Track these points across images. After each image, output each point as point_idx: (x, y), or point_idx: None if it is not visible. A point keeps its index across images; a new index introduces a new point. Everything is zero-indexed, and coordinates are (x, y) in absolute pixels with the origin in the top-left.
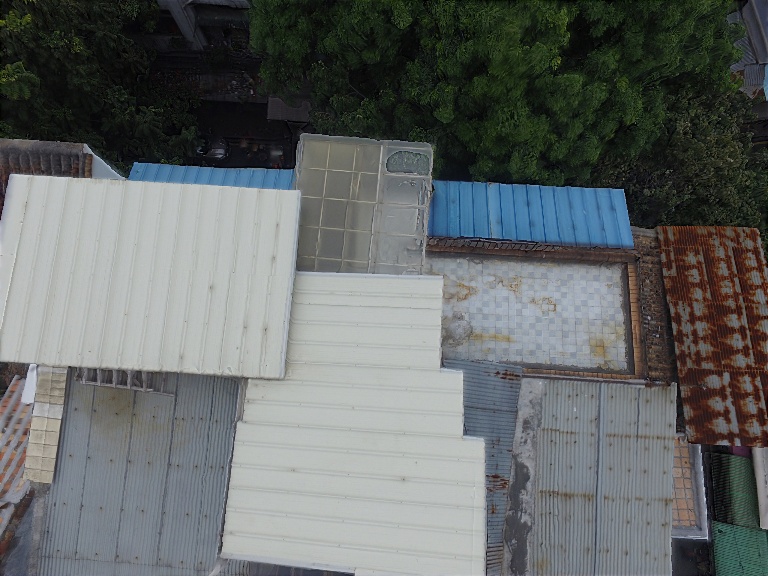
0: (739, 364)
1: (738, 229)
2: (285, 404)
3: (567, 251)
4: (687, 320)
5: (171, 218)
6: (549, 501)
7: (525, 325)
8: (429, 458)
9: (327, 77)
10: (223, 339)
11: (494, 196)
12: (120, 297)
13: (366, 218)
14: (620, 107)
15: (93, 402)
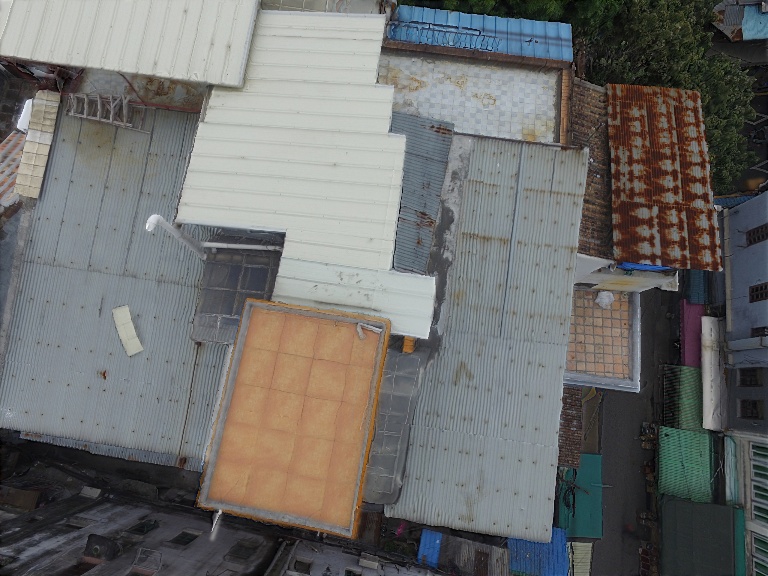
0: (668, 200)
1: (681, 91)
2: (241, 109)
3: (510, 55)
4: (625, 162)
5: None
6: (469, 241)
7: (467, 114)
8: (358, 149)
9: None
10: (193, 51)
11: (454, 21)
12: (108, 13)
13: None
14: None
15: (79, 135)
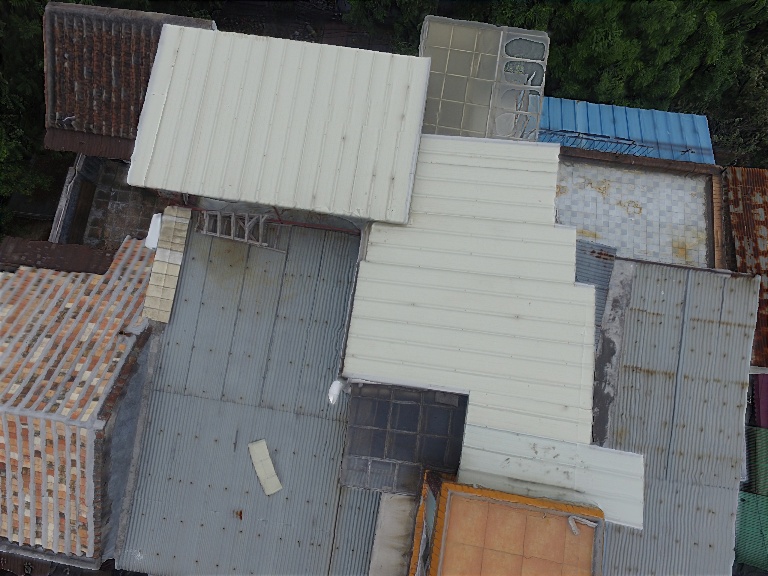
0: None
1: None
2: (407, 247)
3: (655, 159)
4: (751, 254)
5: (310, 74)
6: (632, 375)
7: (611, 224)
8: (542, 300)
9: (418, 2)
10: (354, 184)
11: (582, 112)
12: (260, 140)
13: (484, 94)
14: (706, 41)
15: (210, 253)
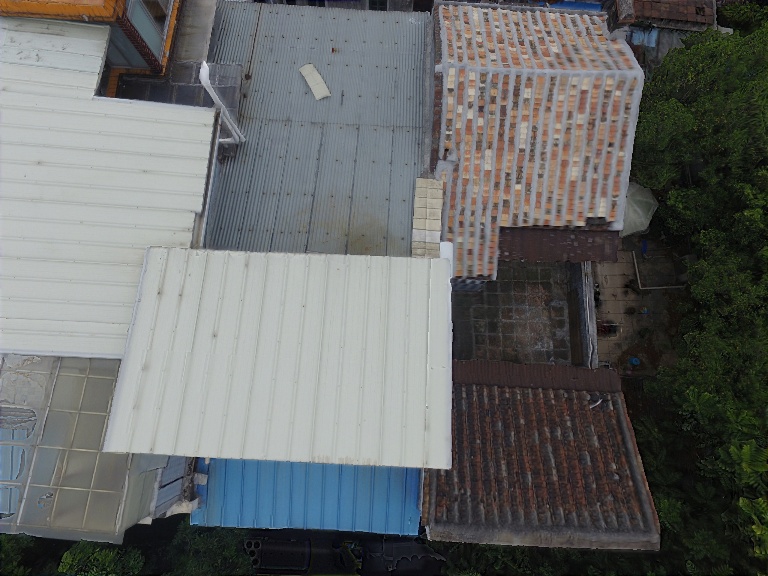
0: None
1: None
2: (151, 227)
3: None
4: None
5: (257, 415)
6: None
7: None
8: (11, 180)
9: None
10: (203, 283)
11: None
12: (311, 324)
13: (54, 427)
14: None
15: (387, 245)
